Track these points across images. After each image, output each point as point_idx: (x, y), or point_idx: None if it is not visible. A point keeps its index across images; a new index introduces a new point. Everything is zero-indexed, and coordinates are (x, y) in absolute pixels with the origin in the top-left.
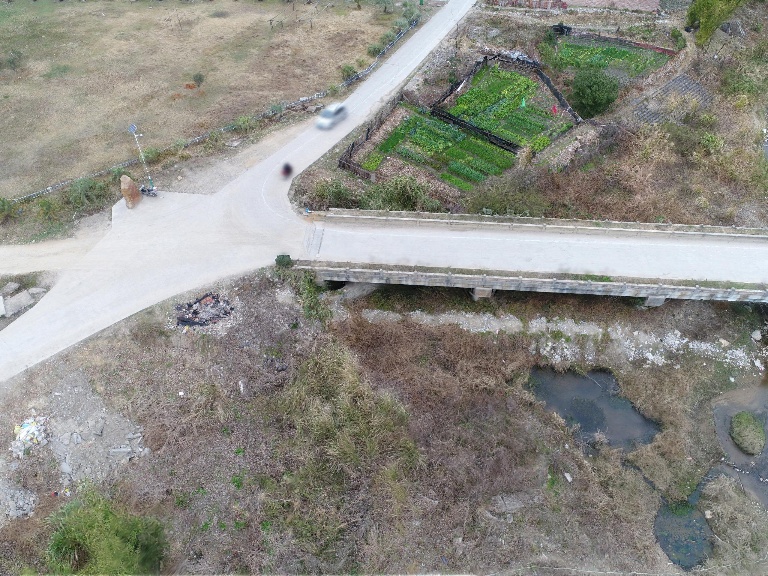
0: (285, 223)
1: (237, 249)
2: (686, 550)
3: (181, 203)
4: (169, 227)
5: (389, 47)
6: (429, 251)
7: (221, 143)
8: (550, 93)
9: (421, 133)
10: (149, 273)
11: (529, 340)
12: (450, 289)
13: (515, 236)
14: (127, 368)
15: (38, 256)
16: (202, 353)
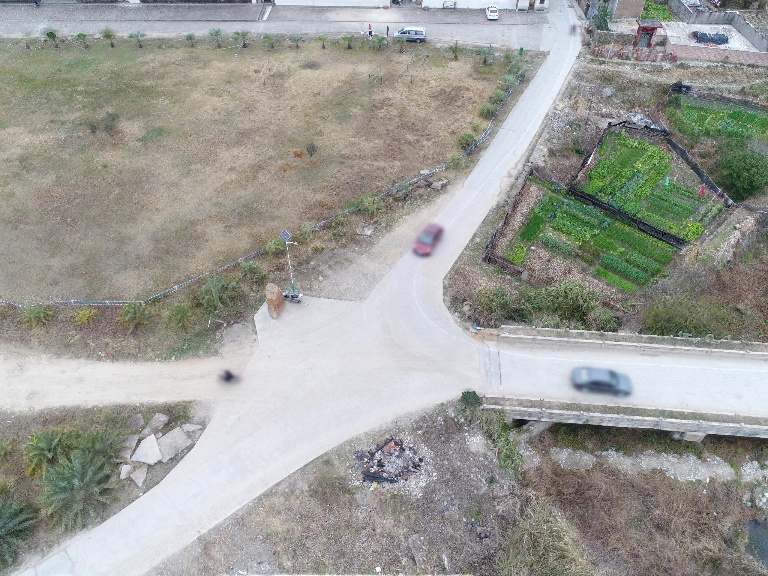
0: (453, 342)
1: (408, 377)
2: None
3: (330, 313)
4: (324, 345)
5: (500, 107)
6: (624, 383)
7: (353, 231)
8: (687, 167)
9: (562, 217)
10: (314, 407)
11: (743, 490)
12: (651, 429)
13: (715, 363)
14: (312, 535)
15: (182, 379)
16: (393, 515)
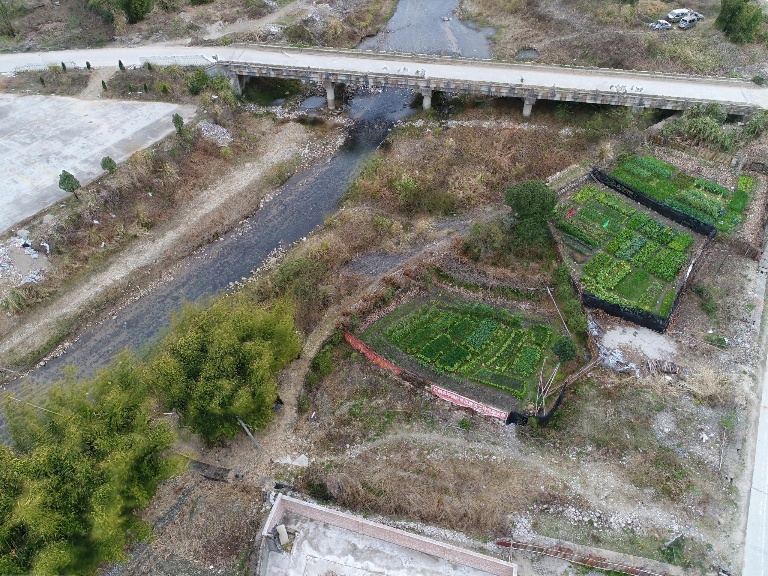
0: None
1: None
2: (529, 52)
3: None
4: None
5: None
6: (670, 88)
7: None
8: None
9: None
10: None
11: None
12: None
13: None
14: None
15: None
16: None
